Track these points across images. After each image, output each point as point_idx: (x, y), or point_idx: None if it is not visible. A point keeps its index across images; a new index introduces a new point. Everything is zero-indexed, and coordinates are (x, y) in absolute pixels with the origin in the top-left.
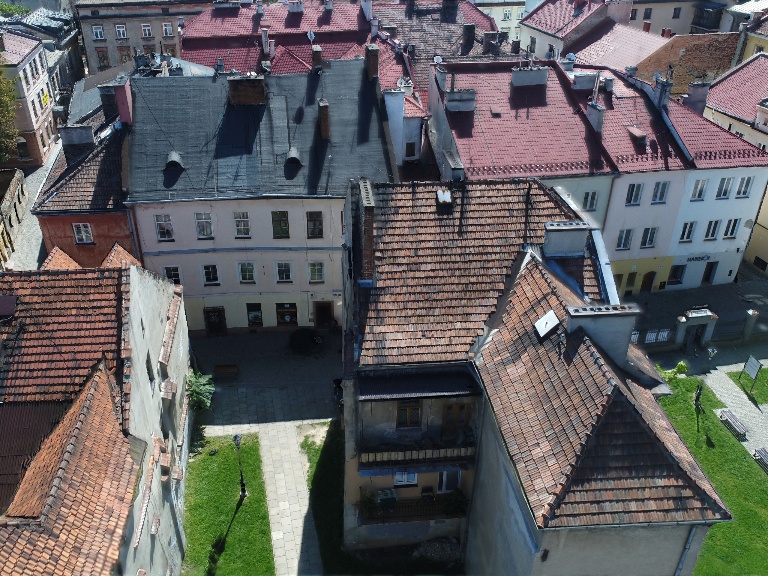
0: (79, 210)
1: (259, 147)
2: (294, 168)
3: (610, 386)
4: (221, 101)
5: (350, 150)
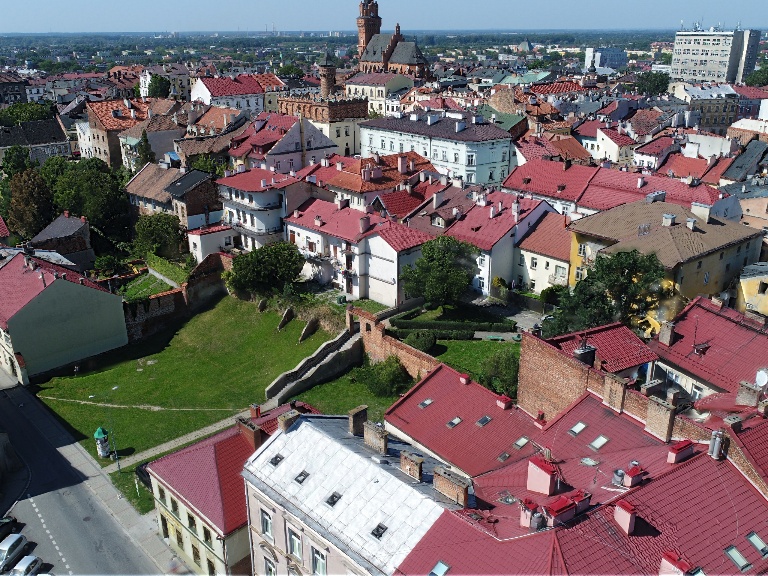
0: None
1: None
2: None
3: None
4: None
5: None
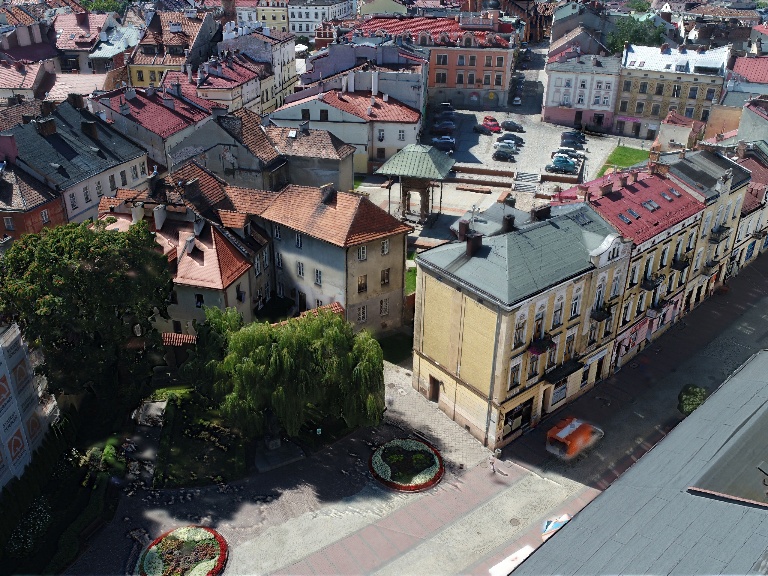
0: (44, 202)
1: (78, 151)
2: (102, 155)
3: (326, 131)
4: (38, 136)
5: (111, 141)
